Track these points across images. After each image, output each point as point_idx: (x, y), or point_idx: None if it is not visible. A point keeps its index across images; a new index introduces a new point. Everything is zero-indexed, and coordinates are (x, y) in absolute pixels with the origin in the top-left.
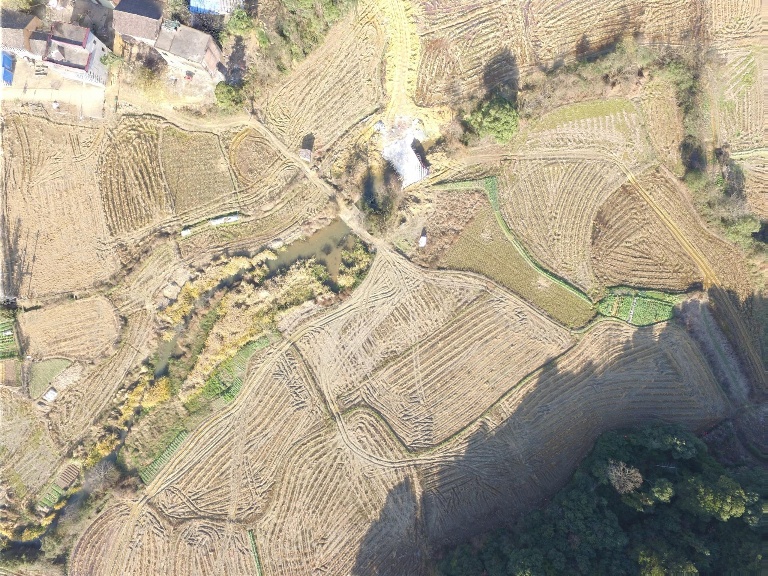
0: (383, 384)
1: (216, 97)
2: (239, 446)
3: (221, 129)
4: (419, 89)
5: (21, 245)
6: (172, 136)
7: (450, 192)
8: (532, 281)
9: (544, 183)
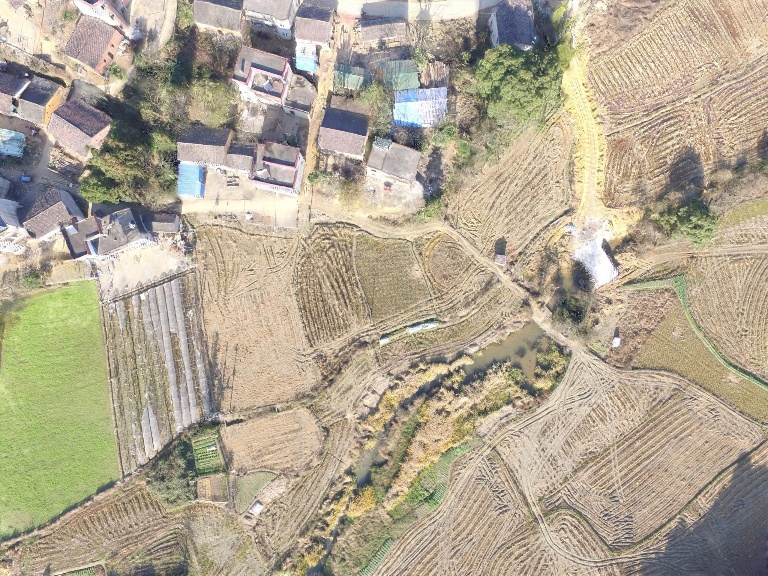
0: (583, 485)
1: (425, 212)
2: (445, 552)
3: (415, 236)
4: (607, 190)
5: (220, 359)
6: (366, 244)
7: (640, 292)
8: (723, 378)
9: (731, 280)
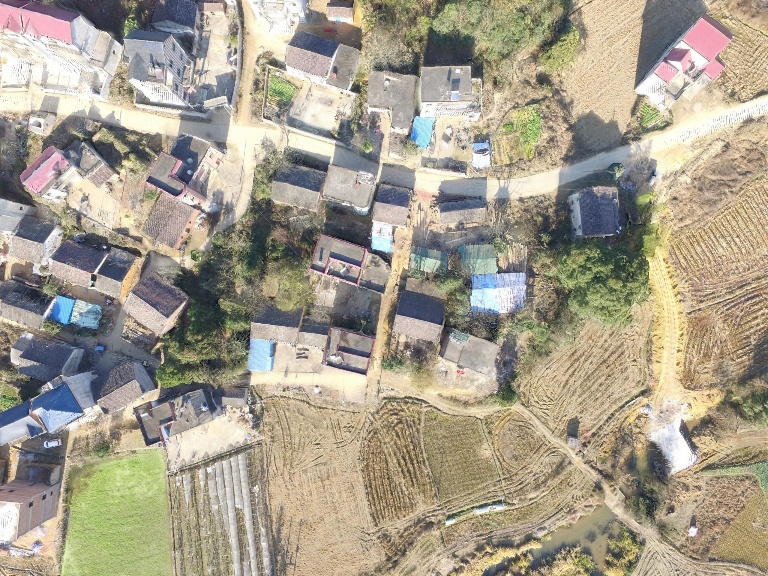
0: None
1: (500, 404)
2: None
3: (485, 414)
4: (686, 370)
5: (284, 534)
6: (434, 420)
7: (719, 478)
8: None
9: None
